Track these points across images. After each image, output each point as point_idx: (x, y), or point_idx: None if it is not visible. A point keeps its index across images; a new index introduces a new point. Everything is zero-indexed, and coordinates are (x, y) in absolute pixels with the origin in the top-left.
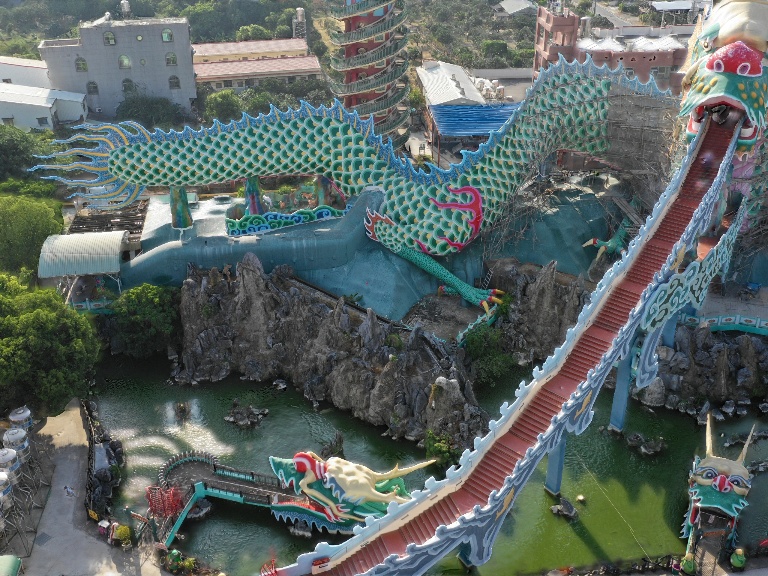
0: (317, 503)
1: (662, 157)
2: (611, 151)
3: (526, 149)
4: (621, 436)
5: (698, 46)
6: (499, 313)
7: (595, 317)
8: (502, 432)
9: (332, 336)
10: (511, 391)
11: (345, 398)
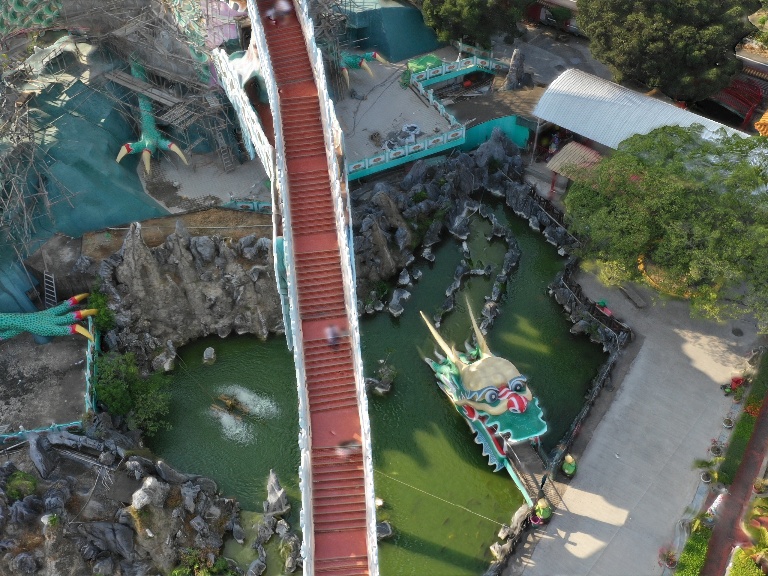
0: None
1: None
2: (66, 13)
3: None
4: None
5: None
6: (100, 325)
7: (299, 310)
8: (312, 544)
9: None
10: (192, 417)
11: None
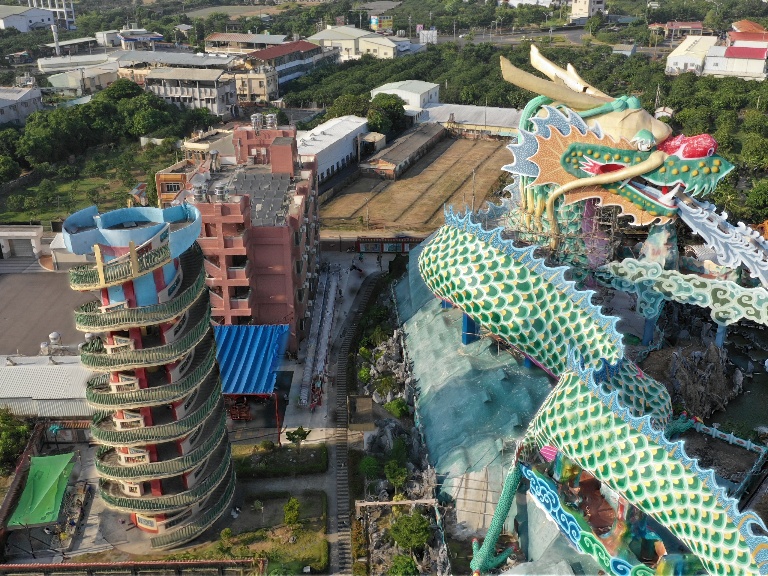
0: None
1: None
2: None
3: None
4: None
5: (620, 152)
6: None
7: None
8: None
9: None
10: None
11: None
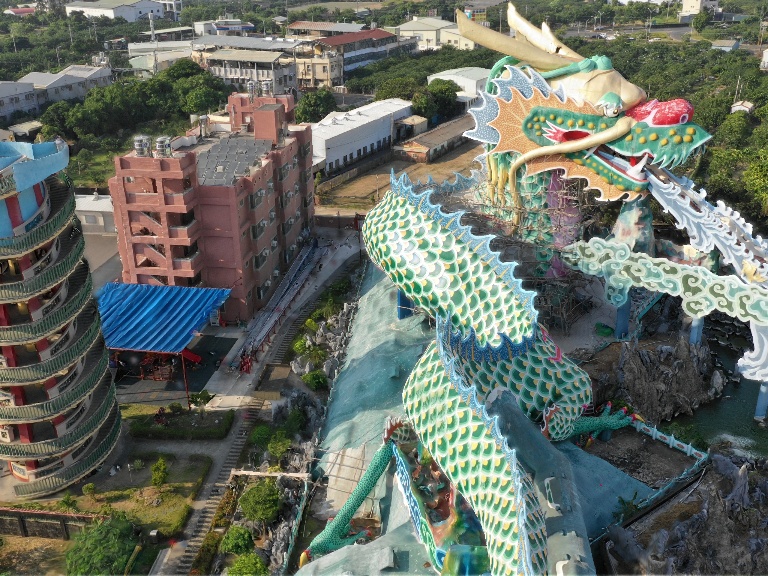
0: None
1: None
2: None
3: None
4: None
5: (584, 117)
6: None
7: None
8: None
9: None
10: None
11: None
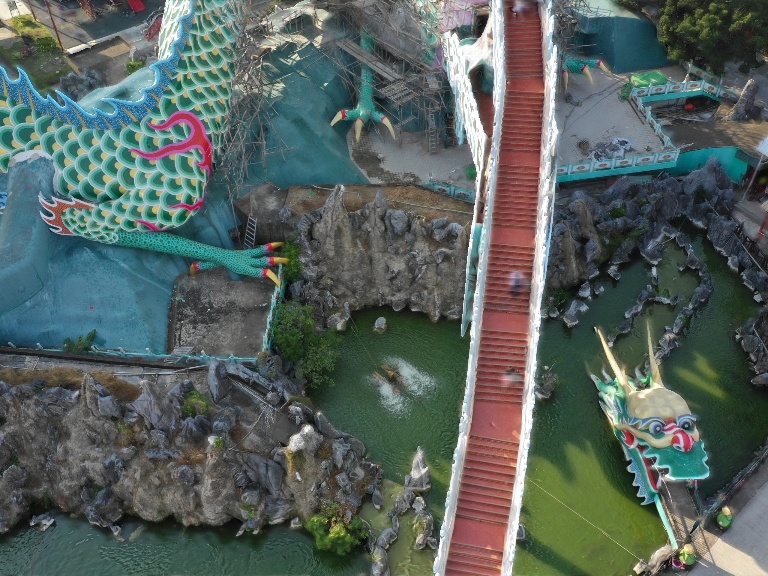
0: None
1: None
2: None
3: (225, 22)
4: None
5: None
6: (288, 275)
7: (483, 298)
8: (452, 526)
9: (96, 432)
10: (354, 379)
11: (158, 508)
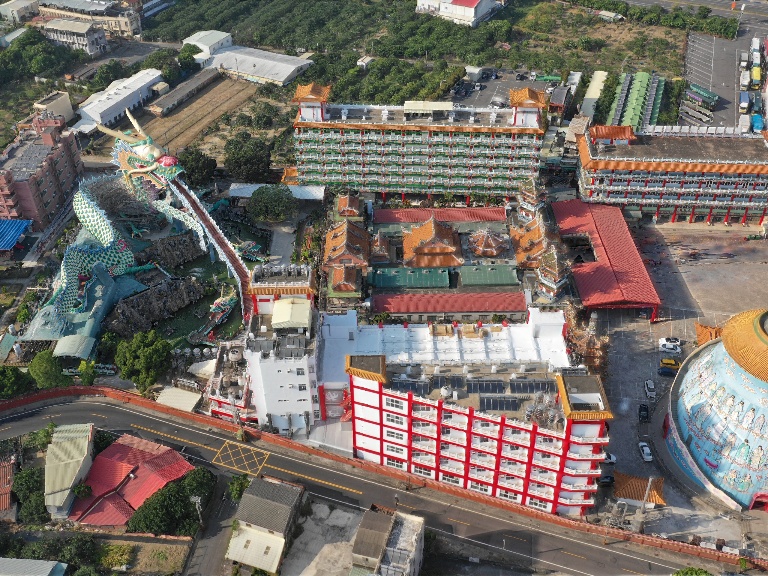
0: (223, 311)
1: (122, 197)
2: None
3: None
4: (217, 261)
5: (144, 162)
6: None
7: None
8: None
9: None
10: None
11: None
